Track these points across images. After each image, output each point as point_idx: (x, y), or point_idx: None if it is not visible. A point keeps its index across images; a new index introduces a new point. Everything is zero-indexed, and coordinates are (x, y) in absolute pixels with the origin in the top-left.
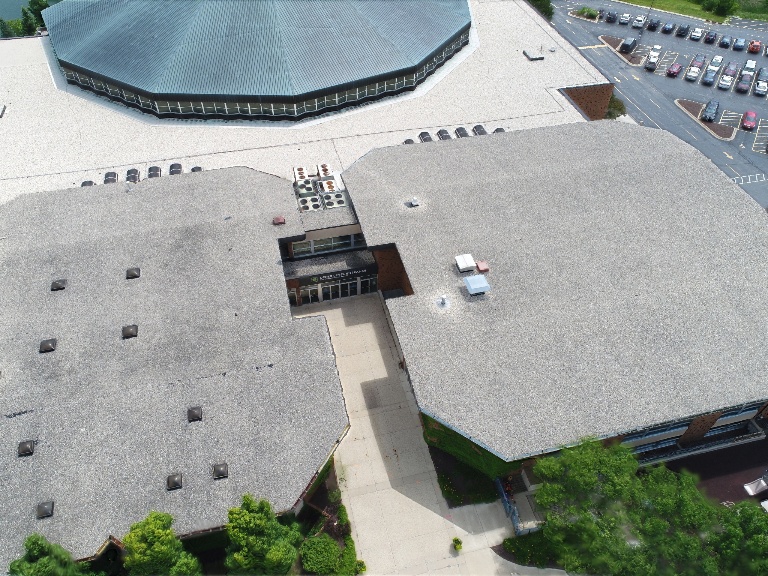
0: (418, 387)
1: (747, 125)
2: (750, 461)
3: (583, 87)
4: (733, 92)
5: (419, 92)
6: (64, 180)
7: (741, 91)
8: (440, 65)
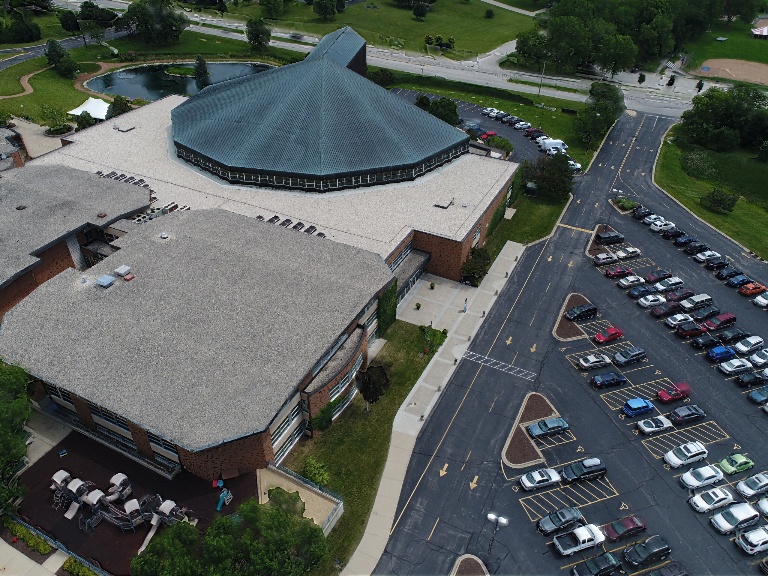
0: (17, 306)
1: (596, 337)
2: (144, 482)
3: (433, 236)
4: (647, 312)
5: (323, 195)
6: (97, 168)
7: (653, 314)
8: (366, 185)
